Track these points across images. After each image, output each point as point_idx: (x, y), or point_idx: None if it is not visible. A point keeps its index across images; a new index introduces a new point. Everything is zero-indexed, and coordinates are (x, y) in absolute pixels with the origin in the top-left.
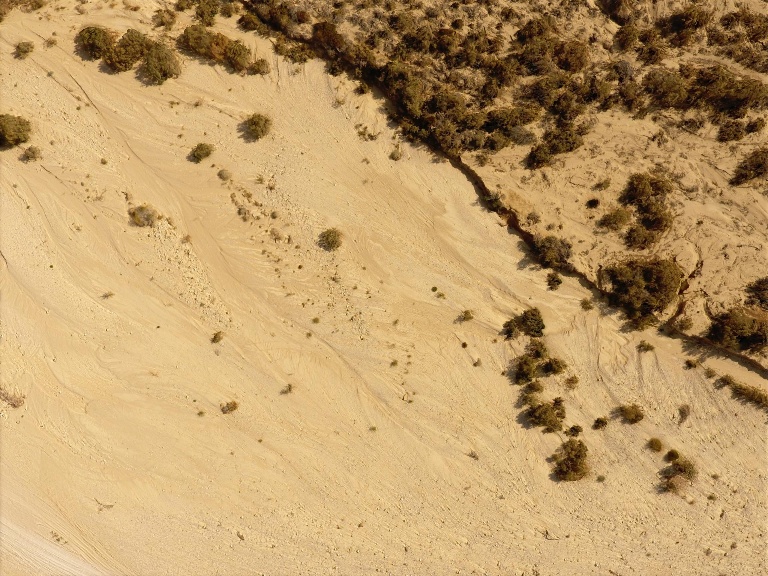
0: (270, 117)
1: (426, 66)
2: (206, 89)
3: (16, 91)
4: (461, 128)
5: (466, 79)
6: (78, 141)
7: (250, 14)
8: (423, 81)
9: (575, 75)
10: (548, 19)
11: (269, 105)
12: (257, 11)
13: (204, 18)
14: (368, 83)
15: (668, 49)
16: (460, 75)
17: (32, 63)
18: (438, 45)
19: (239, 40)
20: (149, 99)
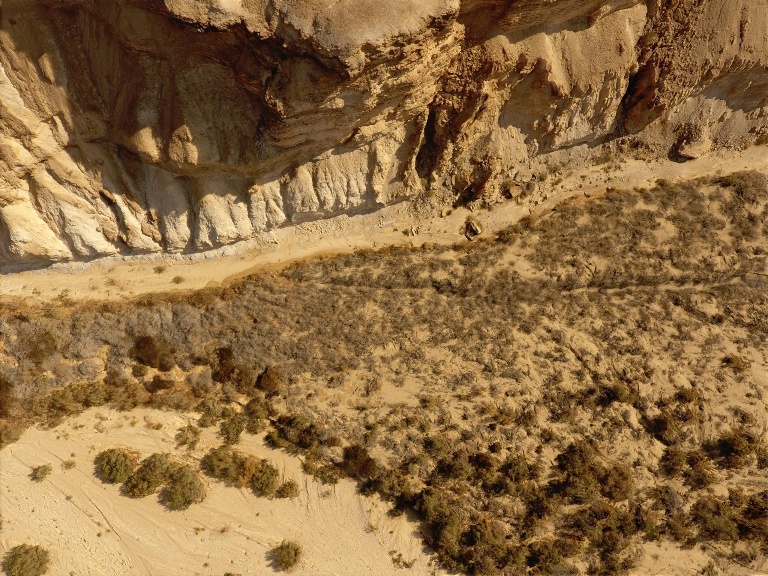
0: (300, 544)
1: (463, 494)
2: (232, 514)
3: (33, 517)
4: (501, 565)
5: (505, 509)
6: (99, 571)
7: (278, 438)
8: (460, 513)
9: (619, 503)
10: (590, 442)
11: (298, 531)
12: (285, 433)
13: (229, 436)
14: (402, 505)
15: (716, 472)
16: (499, 504)
17: (50, 486)
18: (476, 477)
19: (266, 459)
20: (173, 525)
